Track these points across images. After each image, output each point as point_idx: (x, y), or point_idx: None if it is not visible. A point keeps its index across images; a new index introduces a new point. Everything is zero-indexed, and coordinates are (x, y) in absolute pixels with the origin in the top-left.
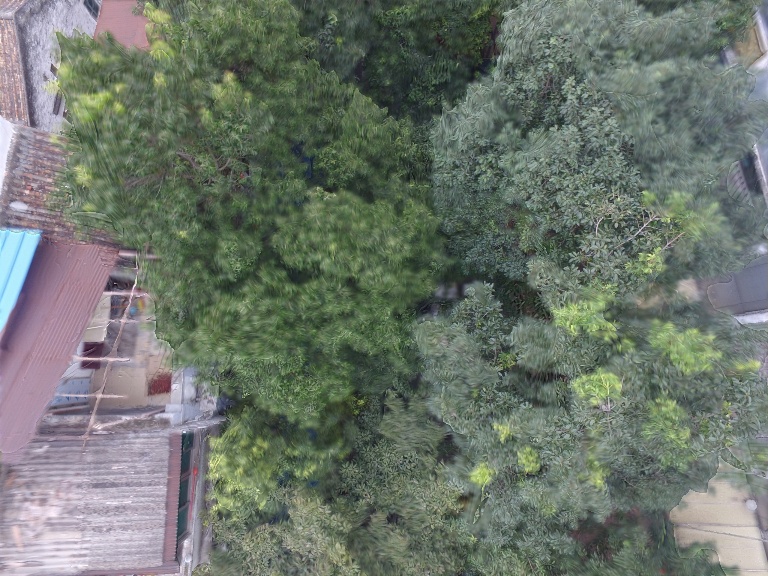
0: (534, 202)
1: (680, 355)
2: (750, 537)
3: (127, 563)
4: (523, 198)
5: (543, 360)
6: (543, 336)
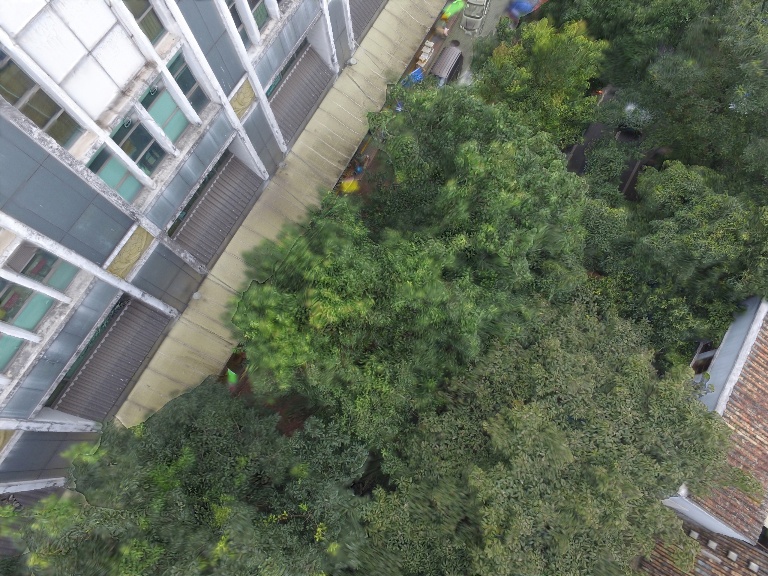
0: None
1: None
2: None
3: None
4: None
5: None
6: None
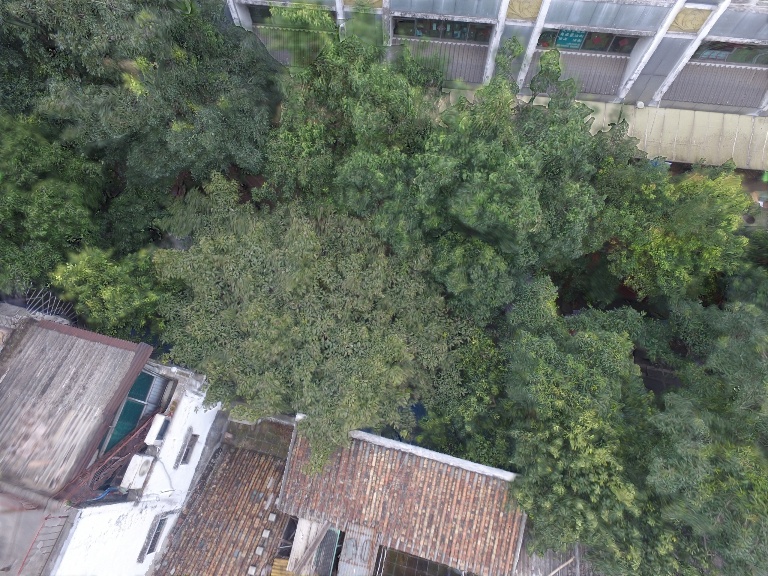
0: None
1: None
2: None
3: (117, 377)
4: None
5: None
6: (108, 70)
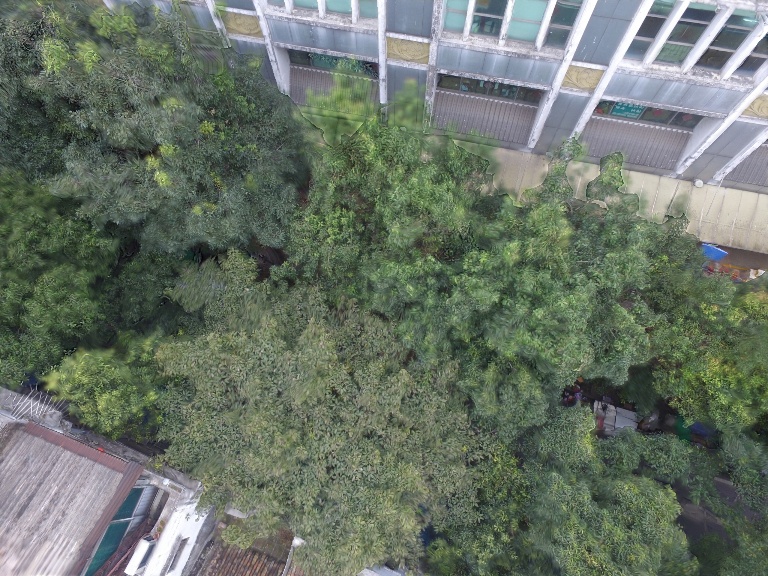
0: (3, 83)
1: (105, 31)
2: None
3: (100, 505)
4: (6, 95)
5: (129, 134)
6: None
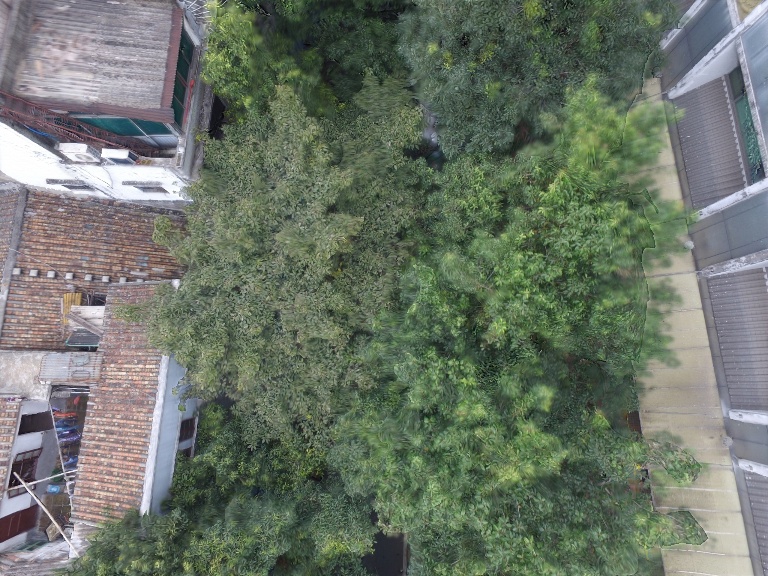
0: None
1: None
2: (685, 272)
3: (131, 101)
4: None
5: None
6: None
